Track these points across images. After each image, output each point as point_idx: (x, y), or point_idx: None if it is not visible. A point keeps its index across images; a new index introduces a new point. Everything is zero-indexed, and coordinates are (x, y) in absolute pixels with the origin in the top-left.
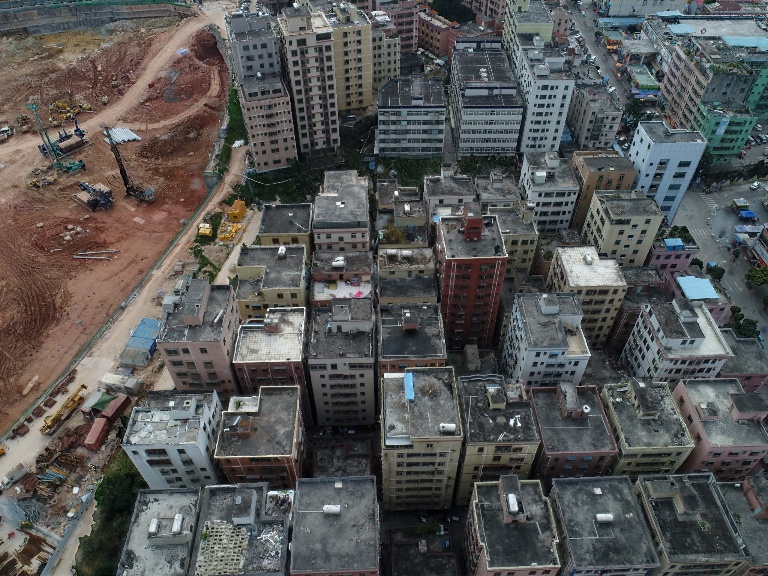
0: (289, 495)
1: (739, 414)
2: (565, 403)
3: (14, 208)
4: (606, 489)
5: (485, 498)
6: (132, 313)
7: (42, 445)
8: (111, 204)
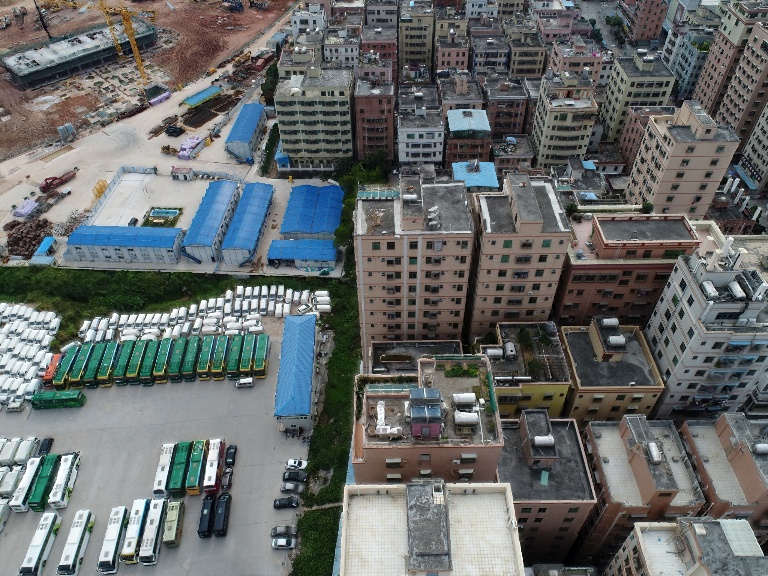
0: None
1: (559, 20)
2: (482, 17)
3: (184, 11)
4: (494, 38)
5: None
6: (268, 35)
7: (233, 70)
8: (242, 8)
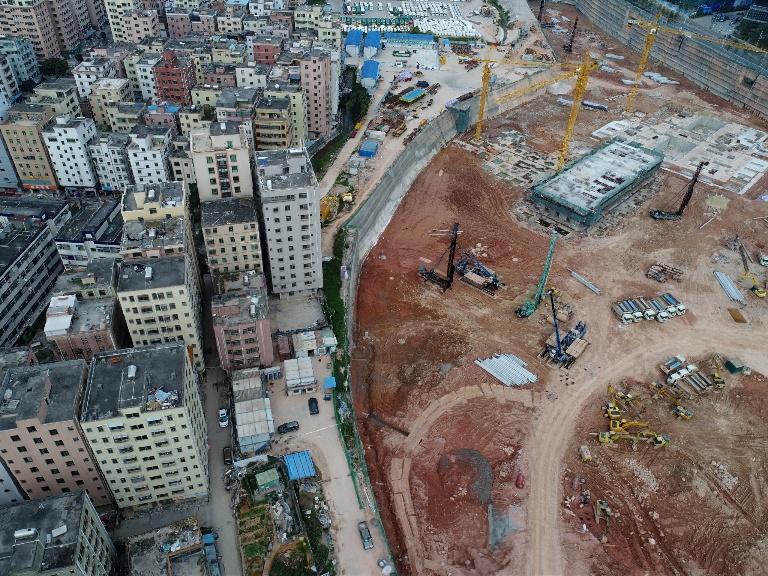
0: None
1: None
2: None
3: None
4: None
5: None
6: None
7: None
8: None
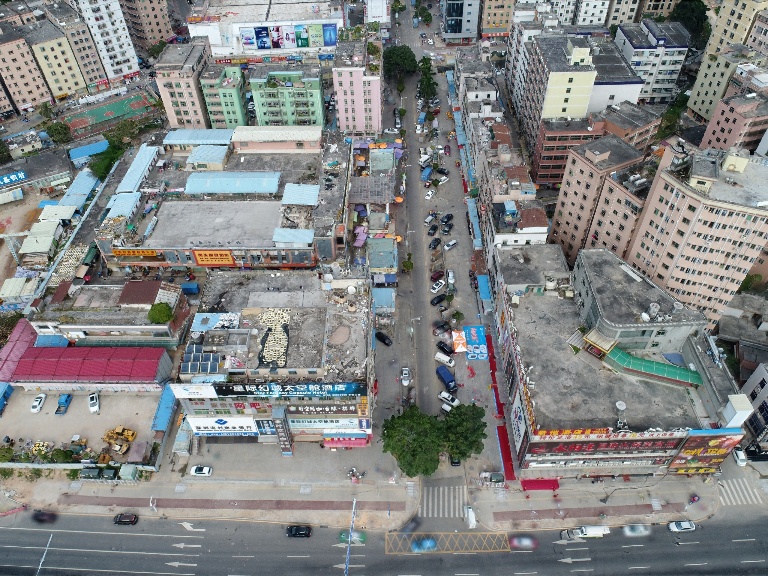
0: None
1: None
2: None
3: None
4: None
5: None
6: None
7: None
8: None
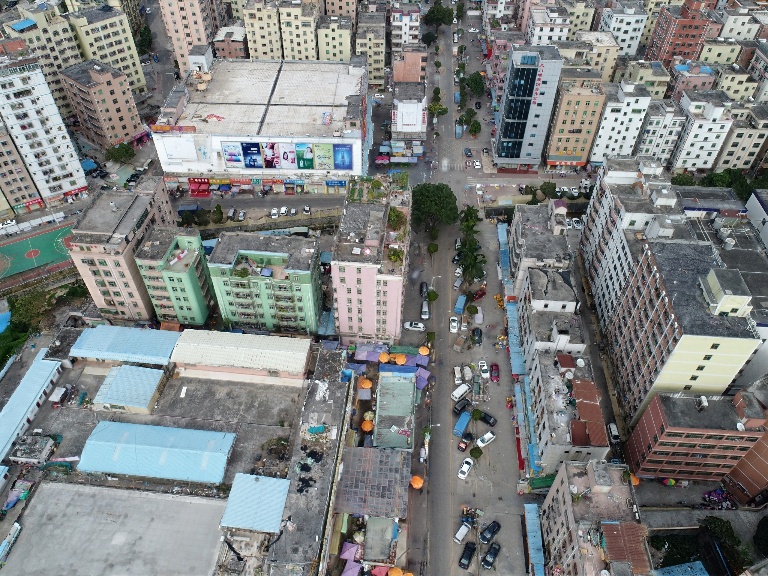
0: None
1: None
2: None
3: None
4: None
5: None
6: None
7: None
8: None
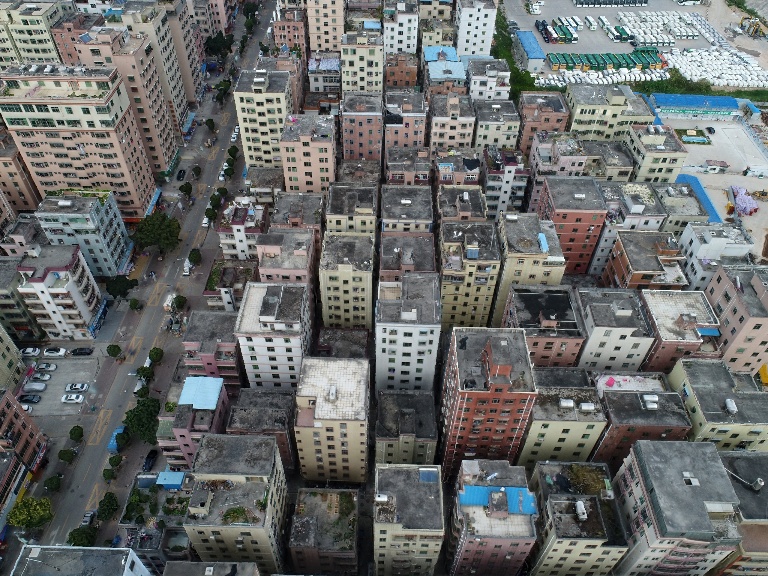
0: (609, 222)
1: None
2: None
3: None
4: (398, 217)
5: (479, 215)
6: None
7: None
8: None
